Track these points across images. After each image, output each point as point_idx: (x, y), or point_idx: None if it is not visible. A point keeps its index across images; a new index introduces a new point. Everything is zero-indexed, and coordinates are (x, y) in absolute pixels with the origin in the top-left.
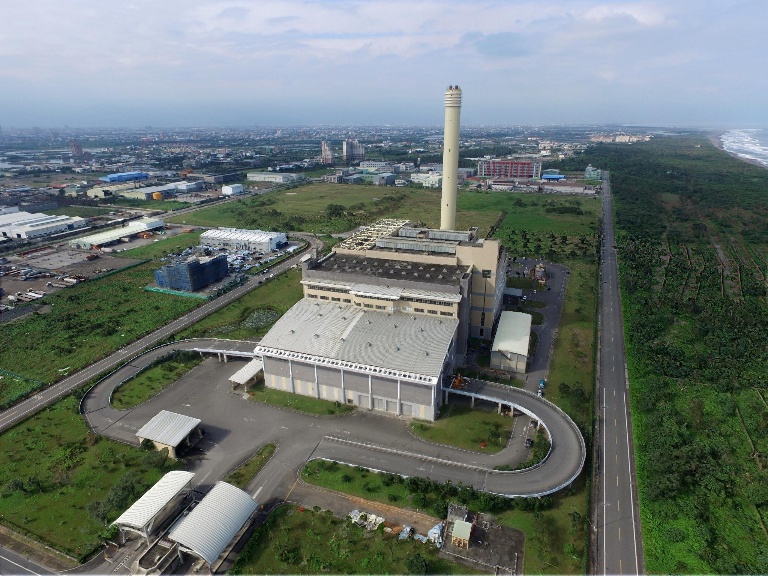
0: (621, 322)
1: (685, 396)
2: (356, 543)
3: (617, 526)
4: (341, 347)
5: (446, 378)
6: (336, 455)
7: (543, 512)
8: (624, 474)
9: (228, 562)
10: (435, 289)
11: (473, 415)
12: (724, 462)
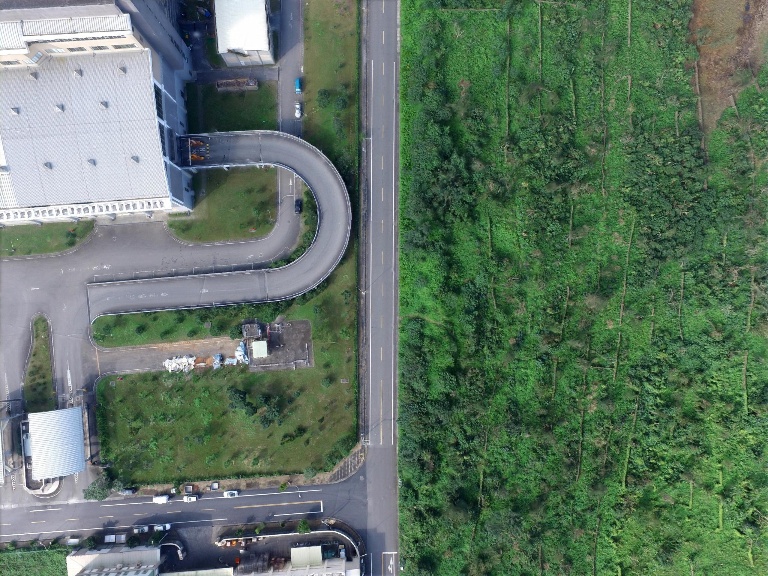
0: None
1: (460, 46)
2: (183, 389)
3: (380, 282)
4: (12, 183)
5: (179, 143)
6: (114, 304)
7: (322, 293)
8: (388, 214)
9: (94, 445)
10: (76, 13)
11: (231, 182)
12: (475, 170)
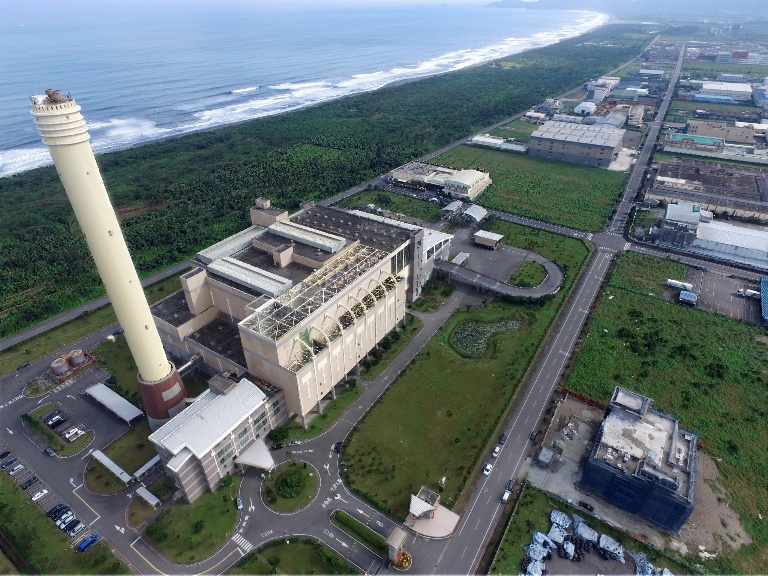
0: (145, 278)
1: None
2: None
3: None
4: None
5: None
6: None
7: None
8: None
9: None
10: None
11: None
12: None
